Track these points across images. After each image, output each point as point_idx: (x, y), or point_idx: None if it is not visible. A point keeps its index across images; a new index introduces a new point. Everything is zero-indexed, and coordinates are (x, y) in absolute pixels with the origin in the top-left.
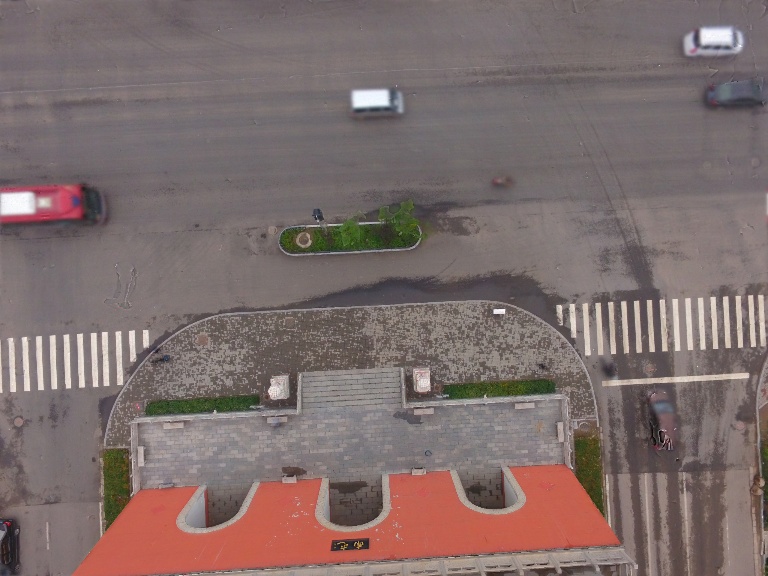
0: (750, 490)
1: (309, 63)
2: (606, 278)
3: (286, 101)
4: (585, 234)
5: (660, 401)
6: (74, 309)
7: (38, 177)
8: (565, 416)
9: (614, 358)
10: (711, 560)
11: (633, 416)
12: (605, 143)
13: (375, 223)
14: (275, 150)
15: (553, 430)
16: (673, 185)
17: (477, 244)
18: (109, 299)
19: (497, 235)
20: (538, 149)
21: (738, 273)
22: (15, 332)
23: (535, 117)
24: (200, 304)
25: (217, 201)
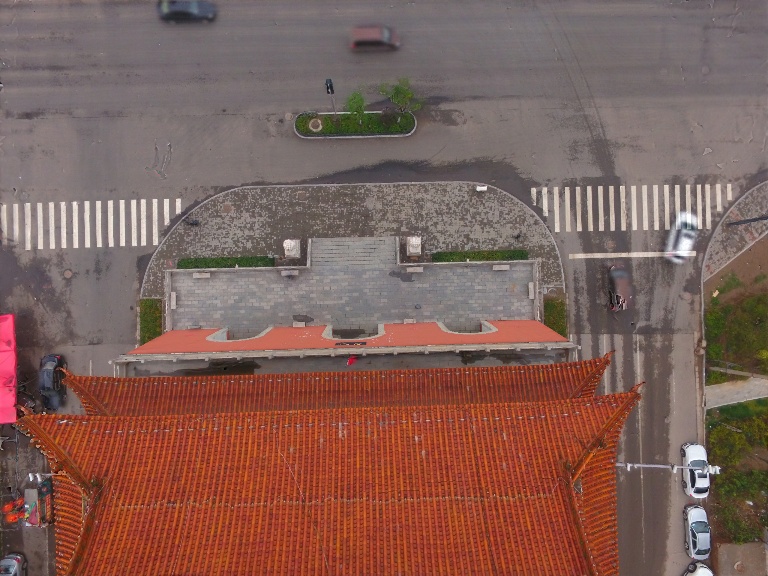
0: (694, 351)
1: None
2: (574, 166)
3: (303, 6)
4: (557, 128)
5: (618, 273)
6: (117, 179)
7: (89, 65)
8: (535, 277)
9: (580, 235)
10: (659, 410)
11: (595, 285)
12: (576, 50)
13: (377, 112)
14: (292, 48)
15: (525, 290)
16: (634, 88)
17: (464, 133)
18: None
19: (481, 126)
20: (518, 53)
21: (688, 165)
22: (67, 197)
23: (516, 26)
24: (225, 178)
25: (242, 90)
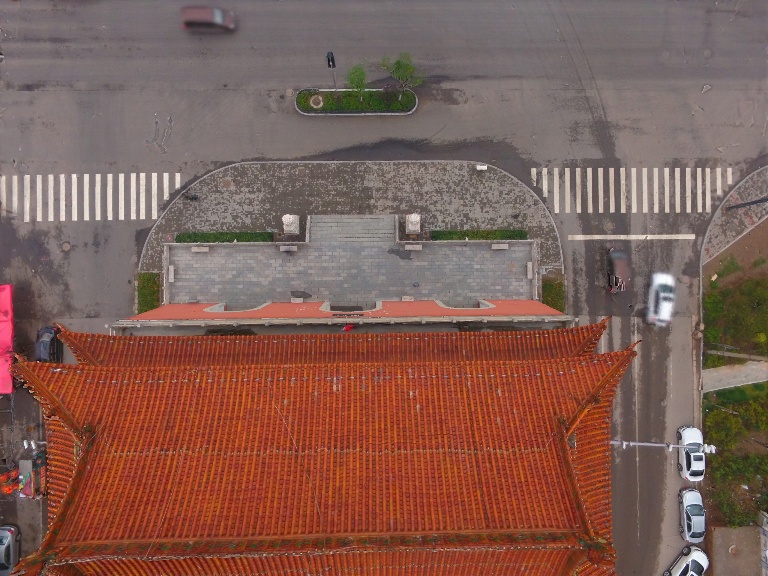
0: (692, 335)
1: None
2: (575, 147)
3: None
4: (558, 108)
5: (617, 255)
6: (117, 152)
7: (91, 38)
8: (534, 256)
9: (579, 216)
10: (656, 393)
11: (594, 266)
12: (579, 31)
13: (378, 90)
14: (295, 24)
15: (524, 270)
16: (636, 70)
17: (465, 113)
18: (149, 141)
19: (483, 106)
20: (521, 33)
21: (689, 148)
22: (66, 169)
23: (519, 6)
24: (225, 153)
25: (243, 65)
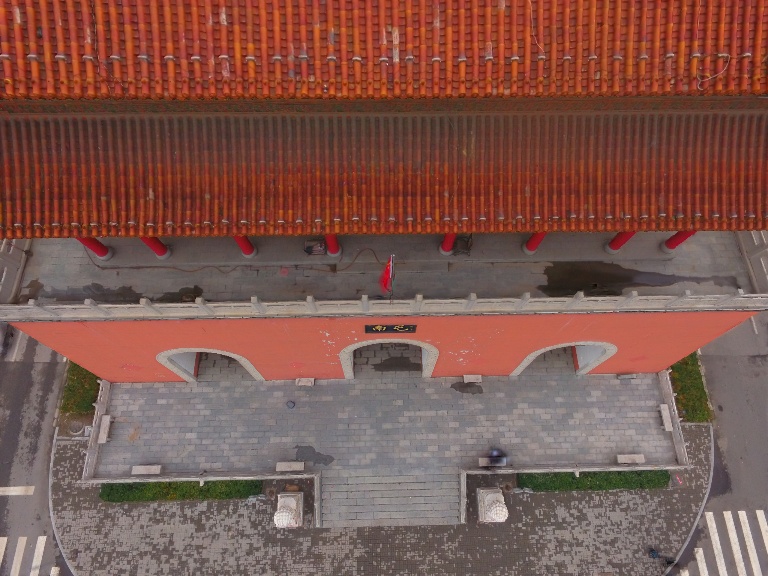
0: None
1: None
2: None
3: None
4: None
5: None
6: None
7: None
8: (92, 453)
9: (5, 531)
10: None
11: (5, 440)
12: None
13: None
14: None
15: (116, 430)
16: None
17: None
18: None
19: None
20: None
21: None
22: None
23: None
24: None
25: None
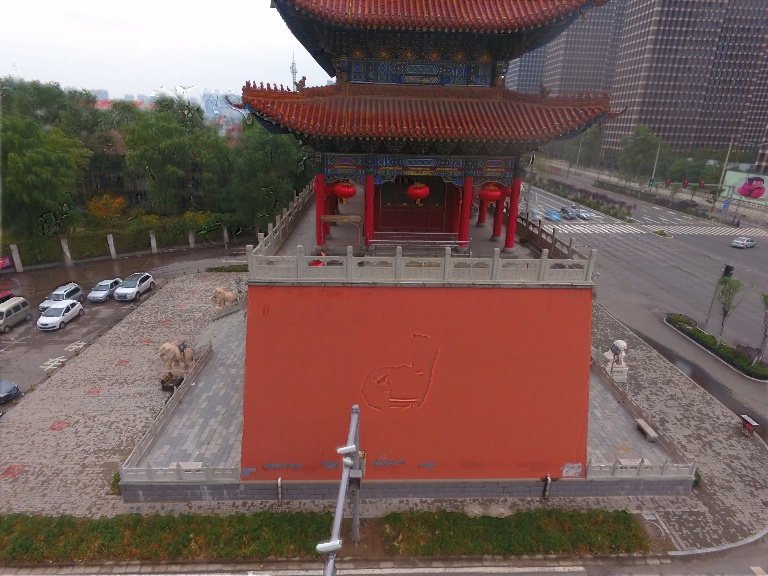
0: None
1: None
2: None
3: None
4: None
5: None
6: None
7: (627, 262)
8: None
9: None
10: None
11: None
12: None
13: None
14: (743, 319)
15: None
16: None
17: None
18: None
19: None
20: None
21: None
22: None
23: None
24: None
25: None
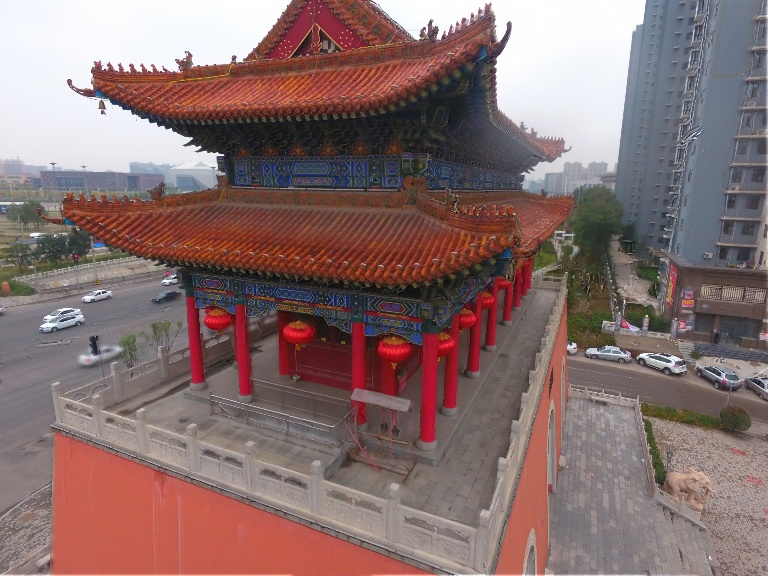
0: None
1: (4, 383)
2: None
3: None
4: None
5: None
6: None
7: None
8: None
9: None
10: None
11: None
12: None
13: None
14: (8, 414)
15: None
16: None
17: None
18: None
19: None
20: None
21: None
22: None
23: None
24: None
25: None
